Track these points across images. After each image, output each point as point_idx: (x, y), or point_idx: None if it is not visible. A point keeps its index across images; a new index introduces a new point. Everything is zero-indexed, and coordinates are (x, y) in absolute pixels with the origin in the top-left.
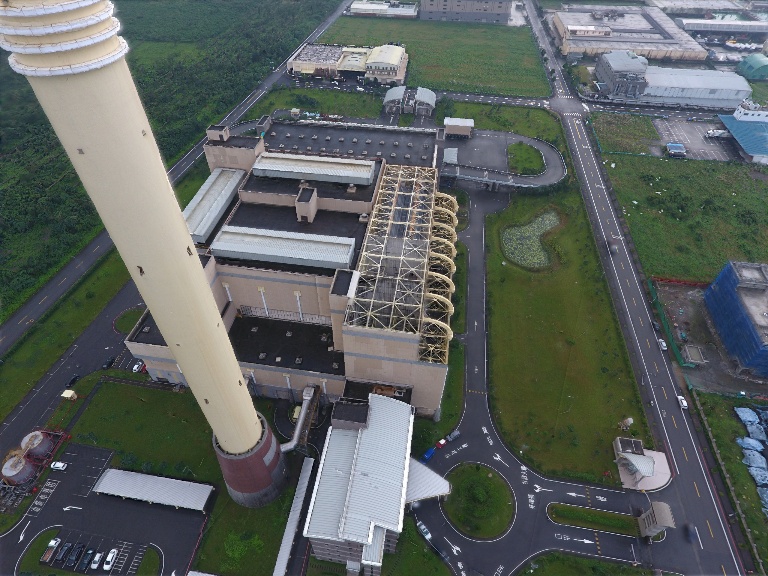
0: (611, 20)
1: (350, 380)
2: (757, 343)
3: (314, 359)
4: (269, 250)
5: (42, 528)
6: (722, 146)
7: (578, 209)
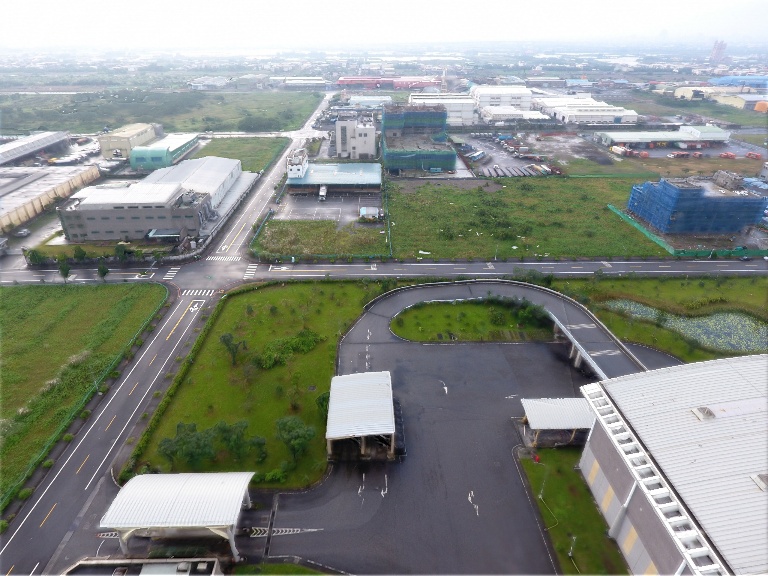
0: None
1: None
2: (762, 202)
3: None
4: None
5: None
6: (346, 196)
7: (601, 274)
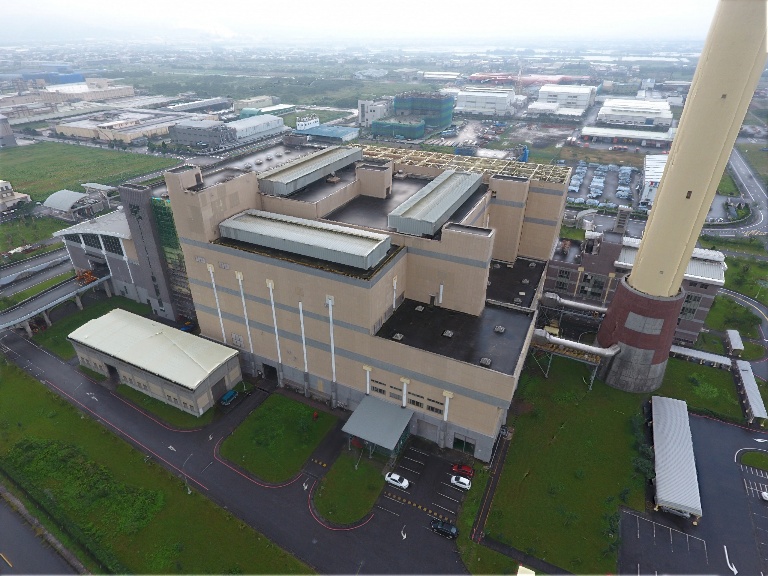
0: (115, 119)
1: (552, 259)
2: None
3: (523, 275)
4: (452, 197)
5: None
6: (319, 143)
7: None
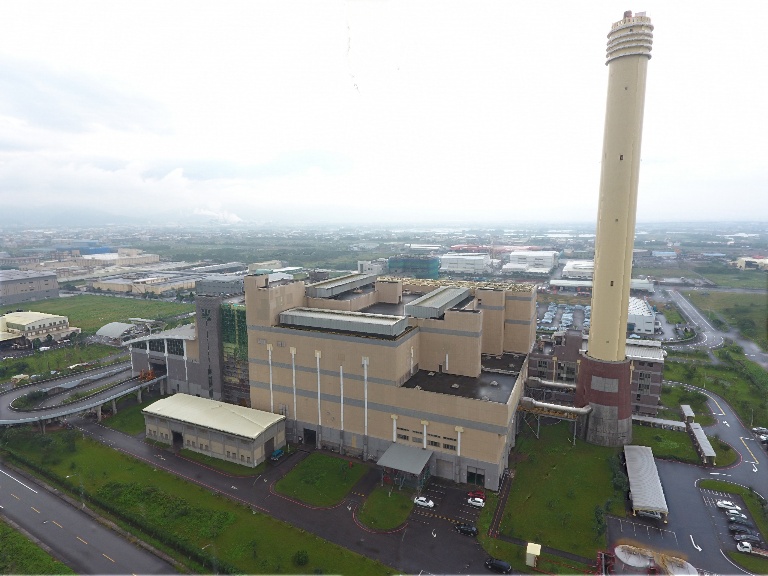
0: None
1: None
2: None
3: None
4: (449, 297)
5: (736, 568)
6: None
7: None
